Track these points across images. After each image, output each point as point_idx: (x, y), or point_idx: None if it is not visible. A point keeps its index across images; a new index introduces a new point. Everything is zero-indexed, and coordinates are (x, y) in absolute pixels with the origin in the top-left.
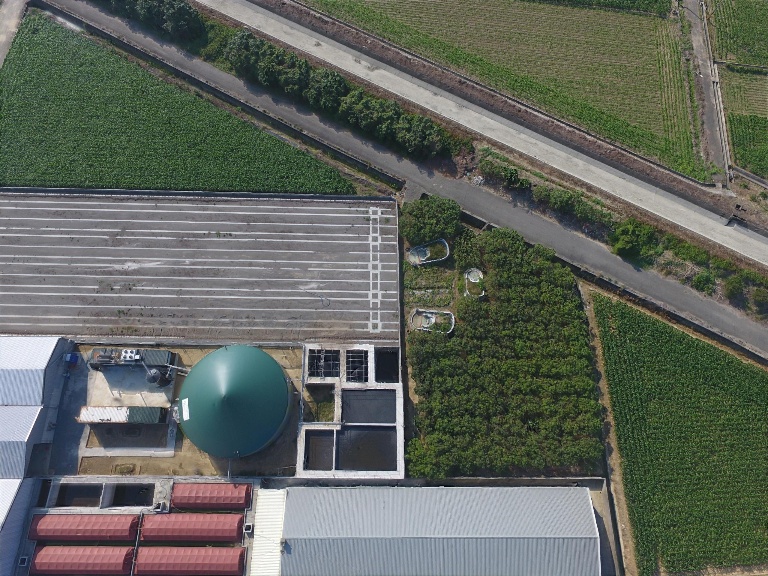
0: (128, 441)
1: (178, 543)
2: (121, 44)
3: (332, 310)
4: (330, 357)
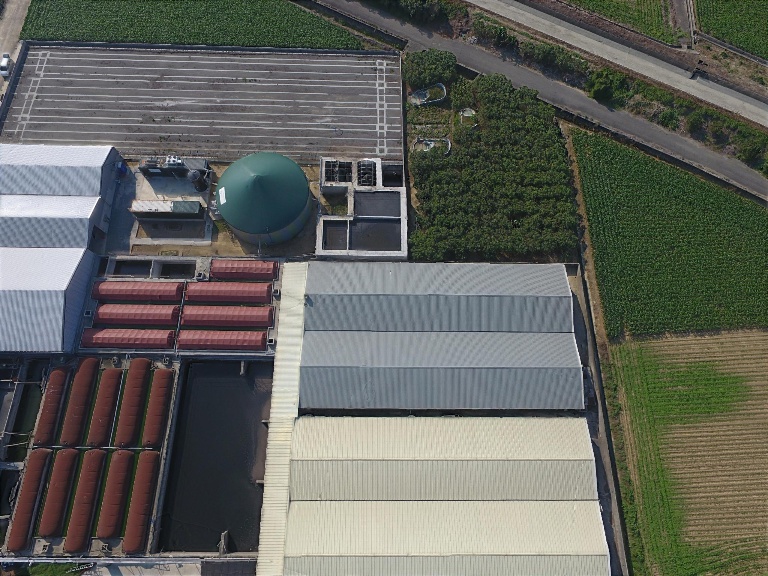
0: (171, 234)
1: (217, 303)
2: None
3: (344, 138)
4: (344, 165)
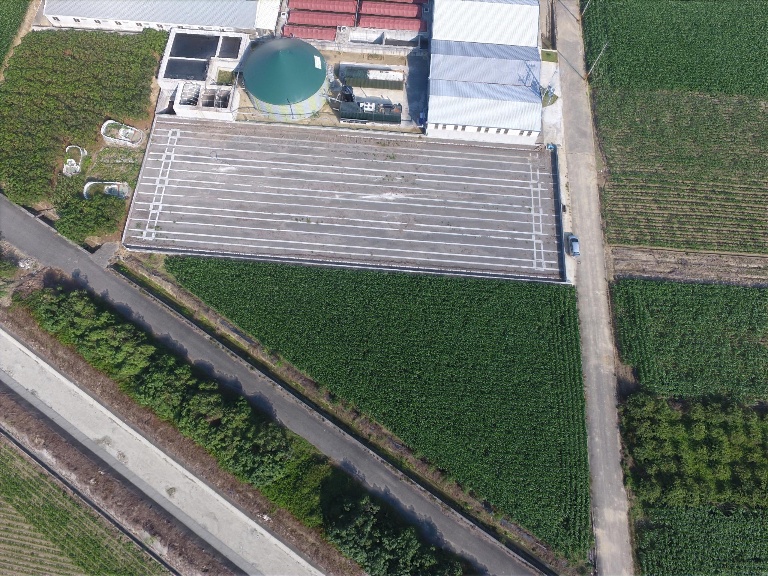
0: None
1: None
2: (447, 502)
3: (209, 148)
4: (209, 99)
